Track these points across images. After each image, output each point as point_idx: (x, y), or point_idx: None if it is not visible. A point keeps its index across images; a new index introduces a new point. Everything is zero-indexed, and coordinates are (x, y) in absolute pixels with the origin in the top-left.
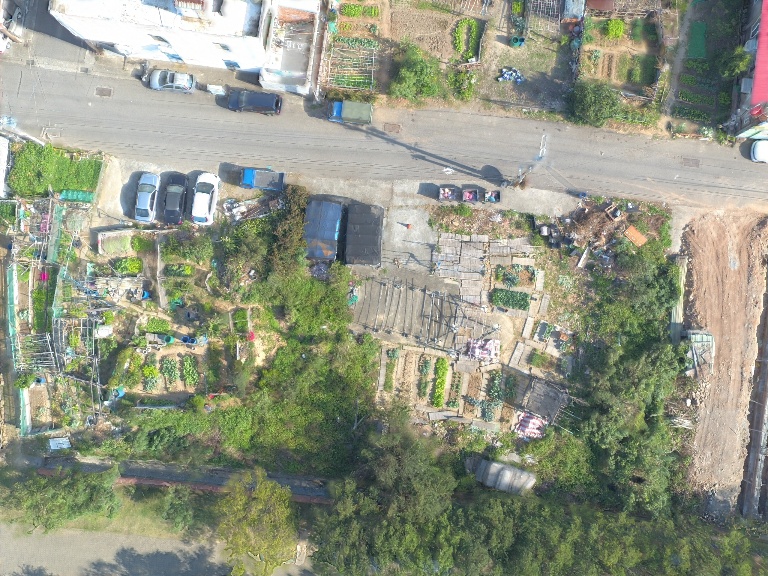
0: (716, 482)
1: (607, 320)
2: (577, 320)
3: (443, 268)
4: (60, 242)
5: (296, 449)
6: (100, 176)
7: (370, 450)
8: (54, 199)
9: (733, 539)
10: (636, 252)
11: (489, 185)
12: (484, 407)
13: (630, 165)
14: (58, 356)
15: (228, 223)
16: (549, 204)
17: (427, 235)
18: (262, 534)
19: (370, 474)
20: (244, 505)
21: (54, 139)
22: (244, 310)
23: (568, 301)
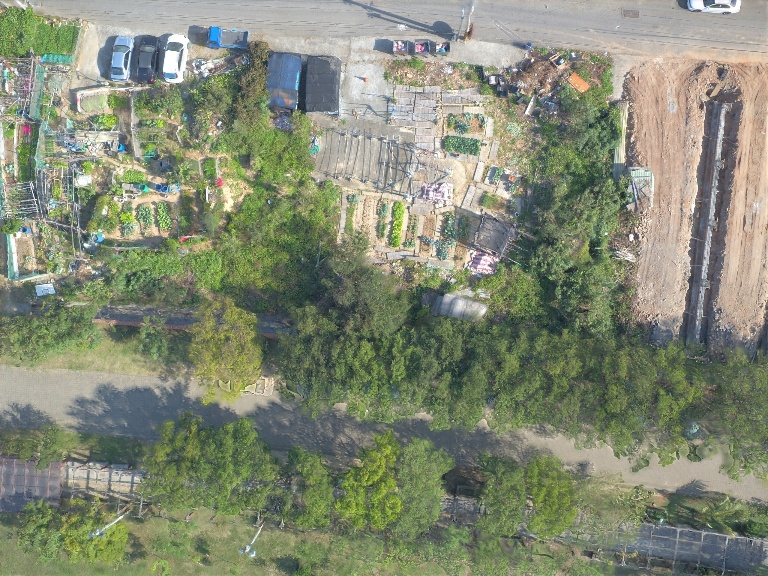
0: (659, 312)
1: (553, 161)
2: (525, 164)
3: (398, 118)
4: (42, 102)
5: (263, 289)
6: (78, 40)
7: (329, 280)
8: (36, 60)
9: (669, 352)
10: (579, 97)
11: (440, 39)
12: (438, 246)
13: (573, 17)
14: (41, 203)
15: (197, 80)
16: (497, 56)
17: (383, 88)
18: (228, 351)
19: (331, 305)
20: (211, 326)
21: (36, 8)
22: (213, 159)
23: (517, 146)
